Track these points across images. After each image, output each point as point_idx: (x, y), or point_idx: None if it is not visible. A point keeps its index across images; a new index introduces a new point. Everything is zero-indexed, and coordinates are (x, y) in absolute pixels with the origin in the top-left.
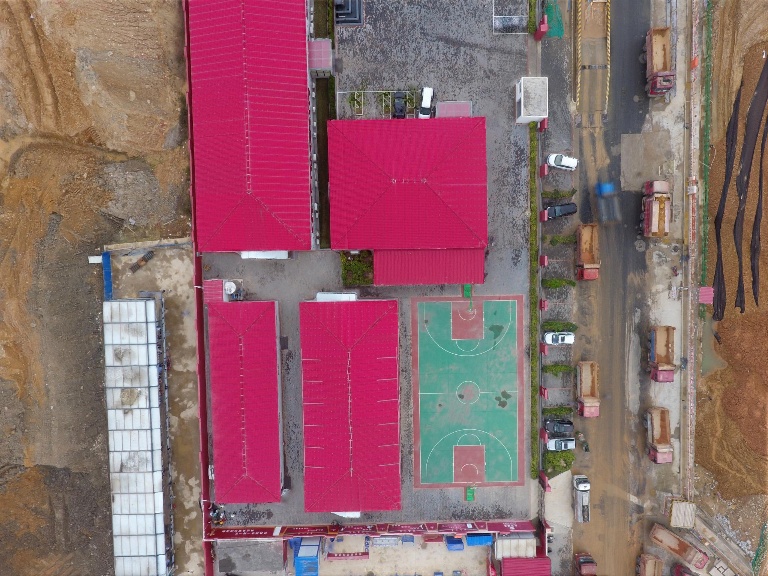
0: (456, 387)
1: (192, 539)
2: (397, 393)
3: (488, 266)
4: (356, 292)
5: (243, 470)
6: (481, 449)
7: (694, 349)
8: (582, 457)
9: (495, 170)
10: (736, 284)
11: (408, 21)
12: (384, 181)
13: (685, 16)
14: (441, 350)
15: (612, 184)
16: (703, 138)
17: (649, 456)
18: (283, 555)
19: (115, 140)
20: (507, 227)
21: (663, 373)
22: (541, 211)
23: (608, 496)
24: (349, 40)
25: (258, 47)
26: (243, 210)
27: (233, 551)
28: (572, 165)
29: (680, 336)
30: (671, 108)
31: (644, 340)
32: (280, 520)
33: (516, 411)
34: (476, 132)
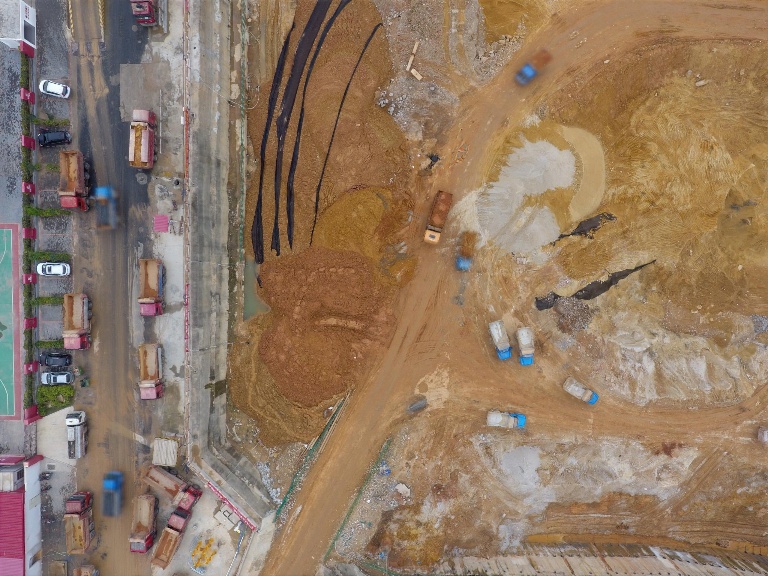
0: None
1: None
2: None
3: None
4: None
5: None
6: None
7: (195, 286)
8: (85, 393)
9: None
10: (272, 226)
11: None
12: None
13: None
14: None
15: (111, 114)
16: None
17: None
18: None
19: None
20: (2, 154)
21: (144, 306)
22: (31, 138)
23: (112, 435)
24: None
25: None
26: None
27: None
28: (57, 91)
29: (183, 272)
30: (170, 39)
31: None
32: None
33: (12, 343)
34: None
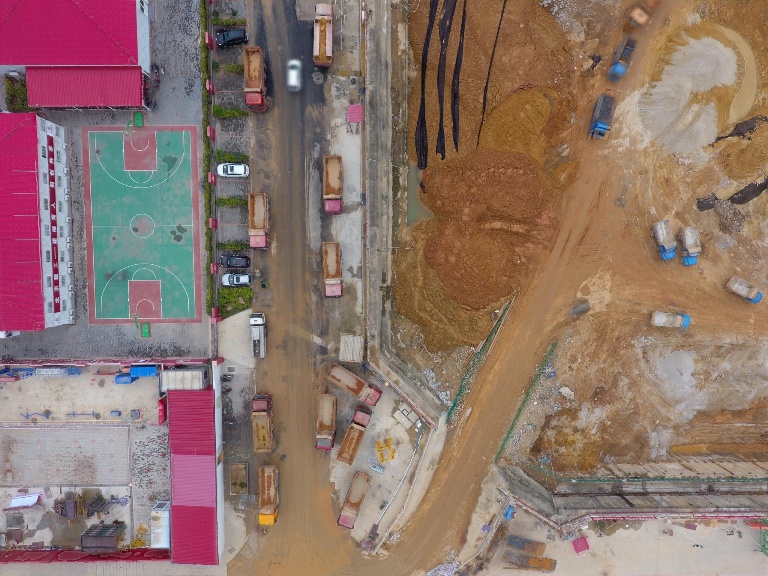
0: (130, 220)
1: None
2: (37, 209)
3: (160, 95)
4: None
5: None
6: (157, 284)
7: (373, 185)
8: (263, 296)
9: None
10: (437, 130)
11: None
12: None
13: None
14: (113, 181)
15: (287, 13)
16: None
17: None
18: None
19: None
20: (179, 55)
21: (329, 202)
22: (210, 37)
23: (291, 336)
24: None
25: None
26: None
27: None
28: None
29: (360, 172)
30: None
31: None
32: None
33: (192, 246)
34: None
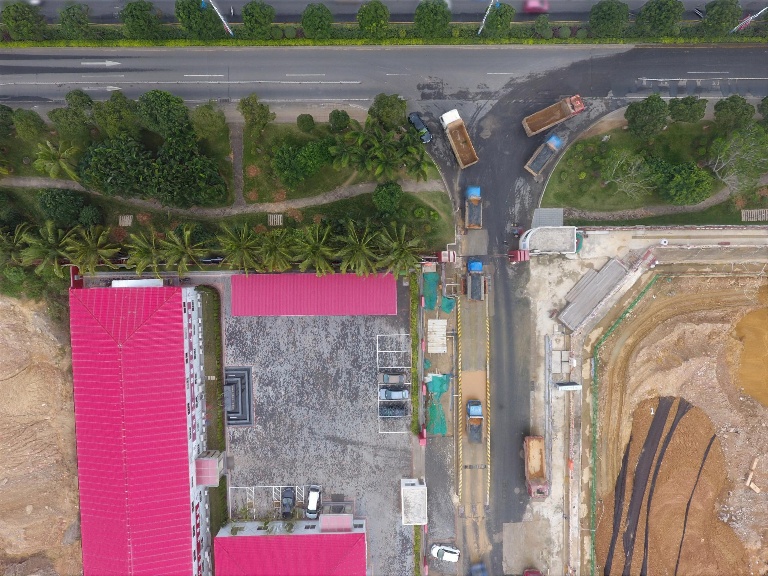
0: None
1: None
2: None
3: None
4: None
5: None
6: None
7: None
8: None
9: (382, 558)
10: None
11: (297, 421)
12: None
13: (563, 415)
14: None
15: (495, 569)
16: (591, 498)
17: None
18: None
19: (14, 549)
20: None
21: None
22: None
23: None
24: (240, 440)
25: (141, 493)
26: None
27: None
28: (453, 560)
29: None
30: (551, 499)
31: None
32: None
33: None
34: (355, 549)
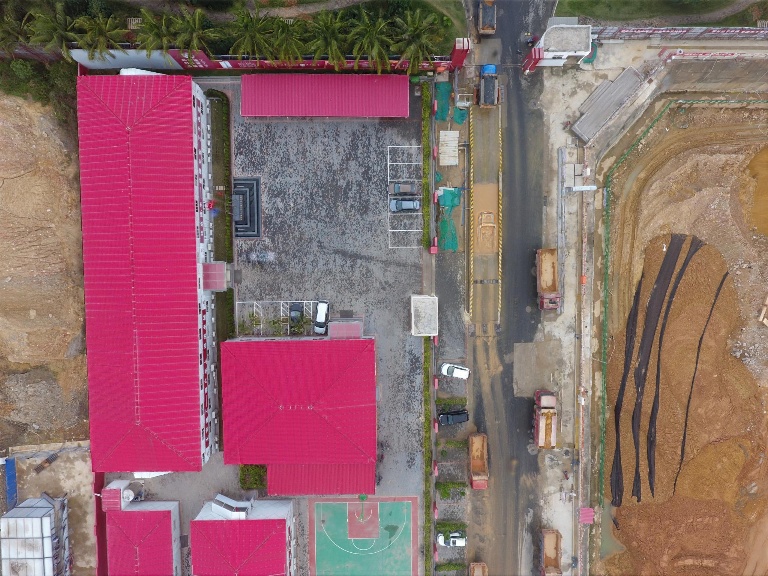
0: None
1: None
2: None
3: (384, 469)
4: (255, 493)
5: None
6: None
7: (584, 549)
8: None
9: (390, 377)
10: (633, 474)
11: (306, 235)
12: (272, 406)
13: (576, 231)
14: (338, 549)
15: (505, 390)
16: (602, 332)
17: None
18: None
19: (16, 355)
20: (402, 431)
21: None
22: (434, 418)
23: None
24: (248, 252)
25: (147, 284)
26: (133, 438)
27: None
28: (463, 377)
29: (571, 536)
30: (562, 319)
31: (536, 539)
32: None
33: None
34: (365, 355)
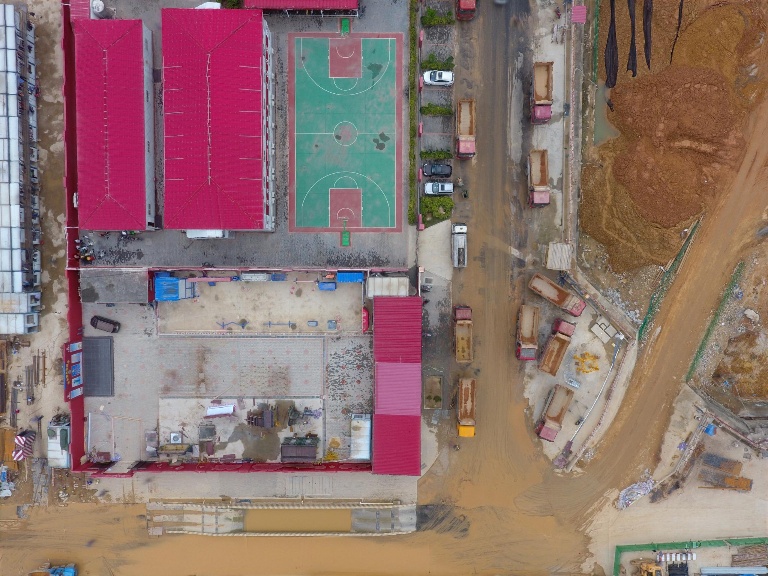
0: (333, 127)
1: (60, 278)
2: (260, 105)
3: (367, 2)
4: None
5: (105, 190)
6: (358, 193)
7: (577, 95)
8: (462, 207)
9: None
10: (628, 47)
11: None
12: None
13: None
14: (318, 88)
15: None
16: None
17: (529, 203)
18: (149, 289)
19: None
20: None
21: (540, 108)
22: None
23: (489, 248)
24: None
25: None
26: None
27: (96, 281)
28: None
29: (563, 82)
30: None
31: (527, 86)
32: (151, 261)
33: (394, 154)
34: None
